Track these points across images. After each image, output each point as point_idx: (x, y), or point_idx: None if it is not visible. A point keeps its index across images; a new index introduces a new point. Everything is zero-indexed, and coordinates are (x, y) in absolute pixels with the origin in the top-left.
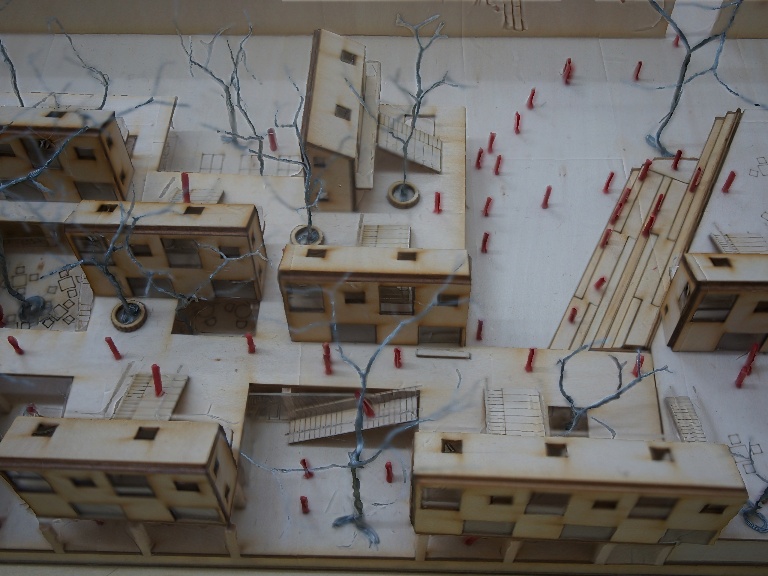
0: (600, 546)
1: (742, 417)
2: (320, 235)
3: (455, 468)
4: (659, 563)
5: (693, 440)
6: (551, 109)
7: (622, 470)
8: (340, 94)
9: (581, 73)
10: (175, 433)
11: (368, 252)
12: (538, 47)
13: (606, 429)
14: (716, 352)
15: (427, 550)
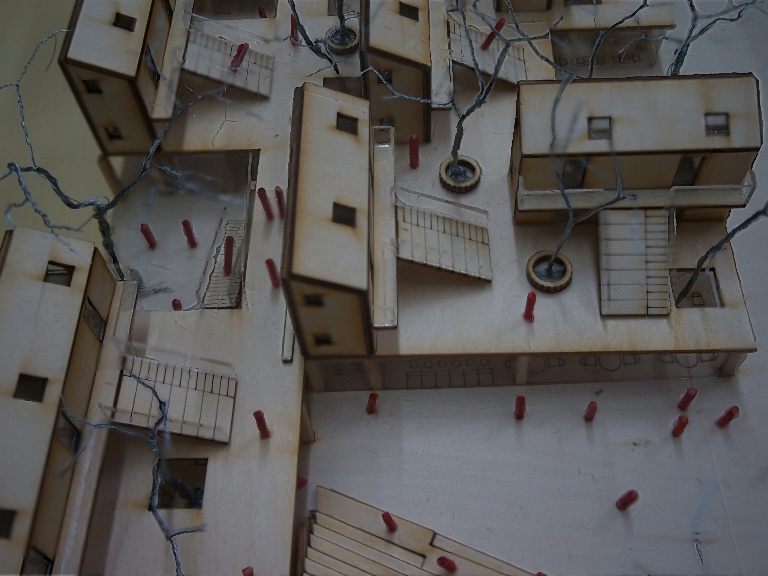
0: None
1: None
2: (463, 183)
3: (15, 267)
4: None
5: None
6: None
7: None
8: (634, 120)
9: None
10: (121, 41)
11: (353, 175)
12: None
13: None
14: None
15: None
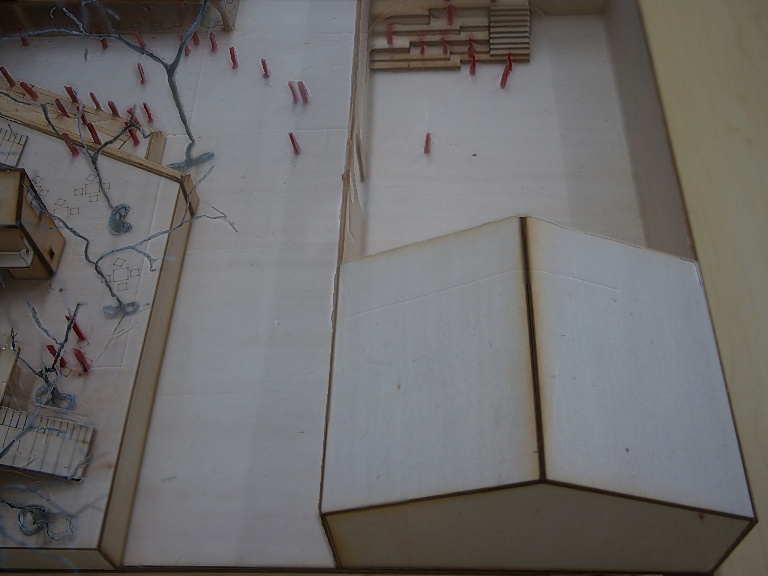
0: None
1: None
2: None
3: None
4: None
5: None
6: (261, 89)
7: None
8: None
9: (310, 112)
10: None
11: None
12: None
13: None
14: None
15: None
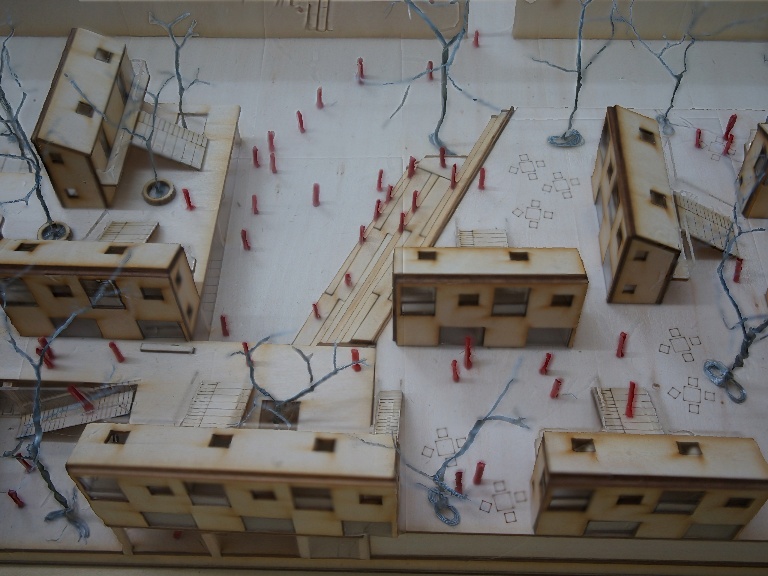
0: (293, 539)
1: (454, 411)
2: (67, 231)
3: (110, 458)
4: (364, 557)
5: (383, 433)
6: (341, 108)
7: (276, 460)
8: (86, 91)
9: (377, 73)
10: None
11: (79, 246)
12: (339, 48)
13: (315, 423)
14: (440, 347)
15: (134, 544)
